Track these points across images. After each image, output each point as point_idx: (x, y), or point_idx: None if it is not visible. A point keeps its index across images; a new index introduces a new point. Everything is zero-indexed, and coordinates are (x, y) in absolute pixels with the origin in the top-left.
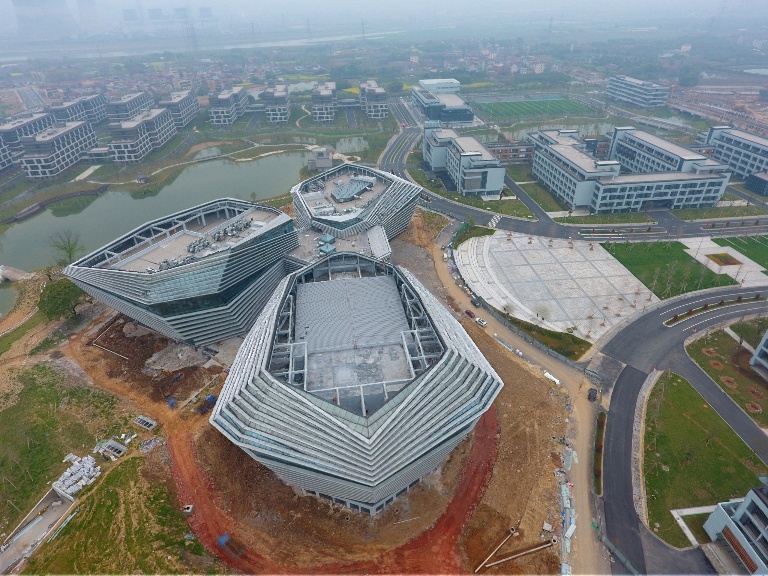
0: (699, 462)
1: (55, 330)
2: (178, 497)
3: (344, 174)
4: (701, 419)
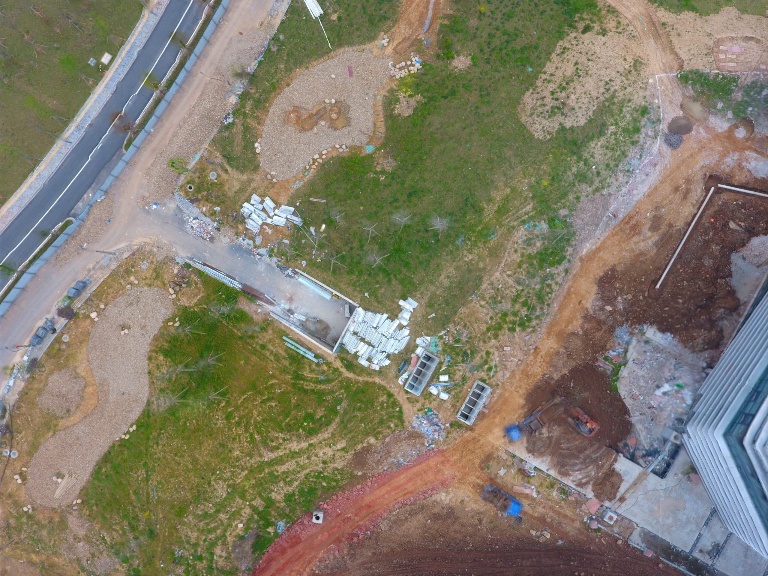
0: None
1: (766, 81)
2: (339, 494)
3: None
4: None
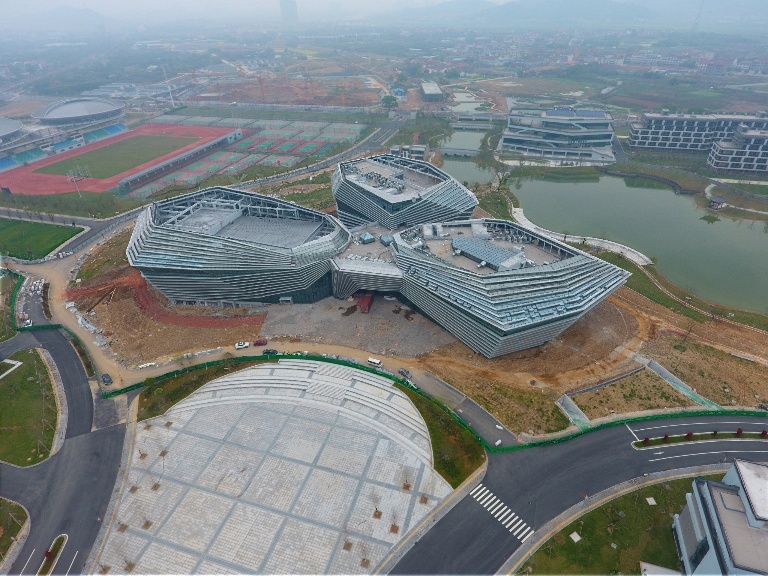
0: (3, 400)
1: None
2: None
3: None
4: (2, 435)
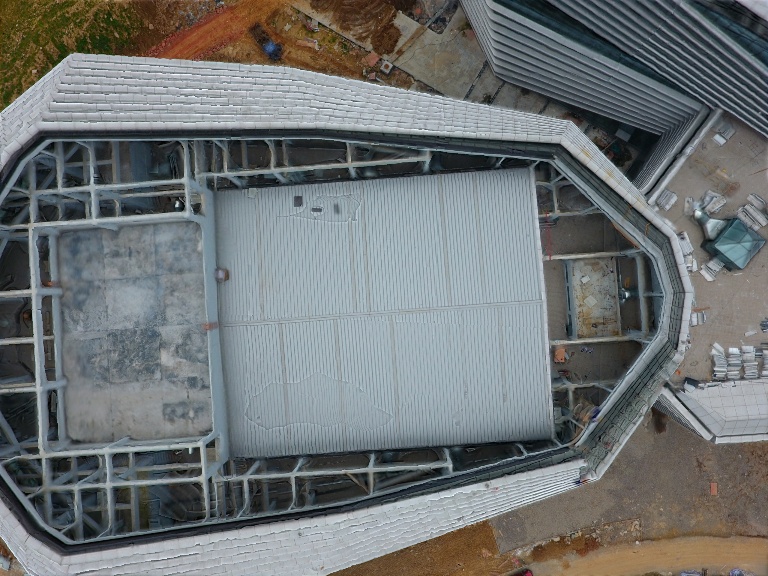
0: None
1: None
2: None
3: None
4: None
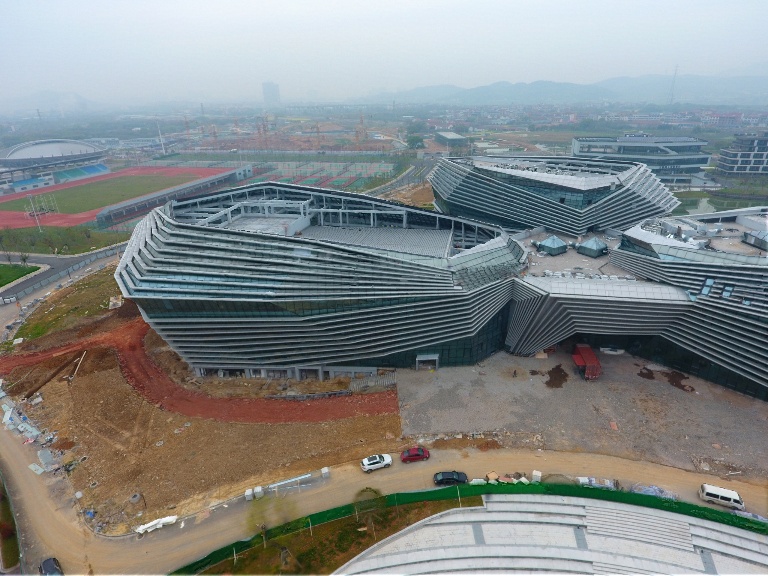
0: None
1: None
2: None
3: None
4: None
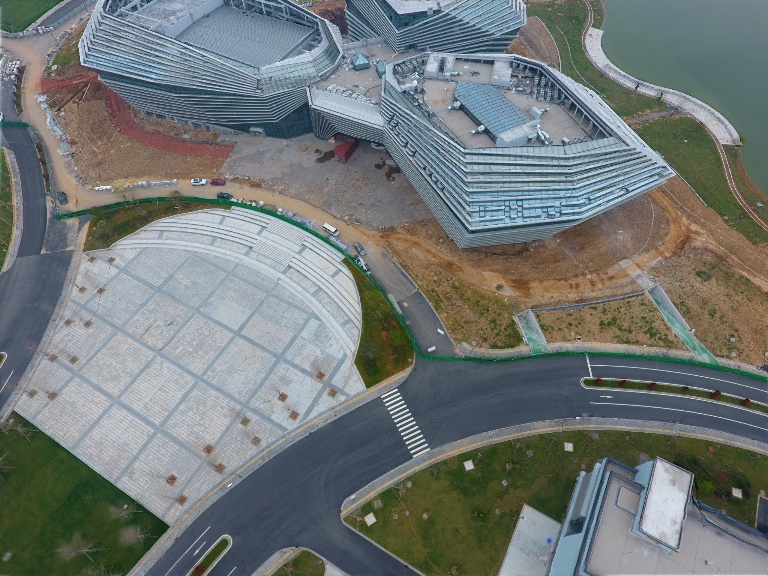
0: None
1: None
2: None
3: (591, 139)
4: None
